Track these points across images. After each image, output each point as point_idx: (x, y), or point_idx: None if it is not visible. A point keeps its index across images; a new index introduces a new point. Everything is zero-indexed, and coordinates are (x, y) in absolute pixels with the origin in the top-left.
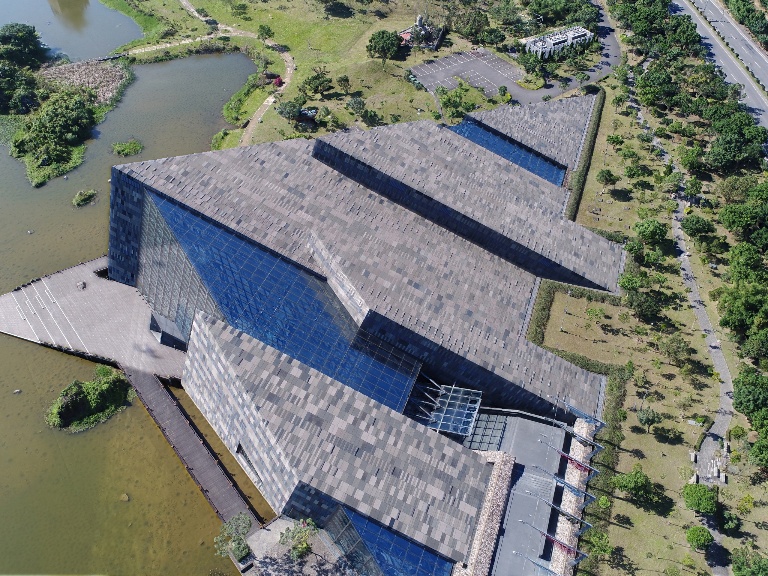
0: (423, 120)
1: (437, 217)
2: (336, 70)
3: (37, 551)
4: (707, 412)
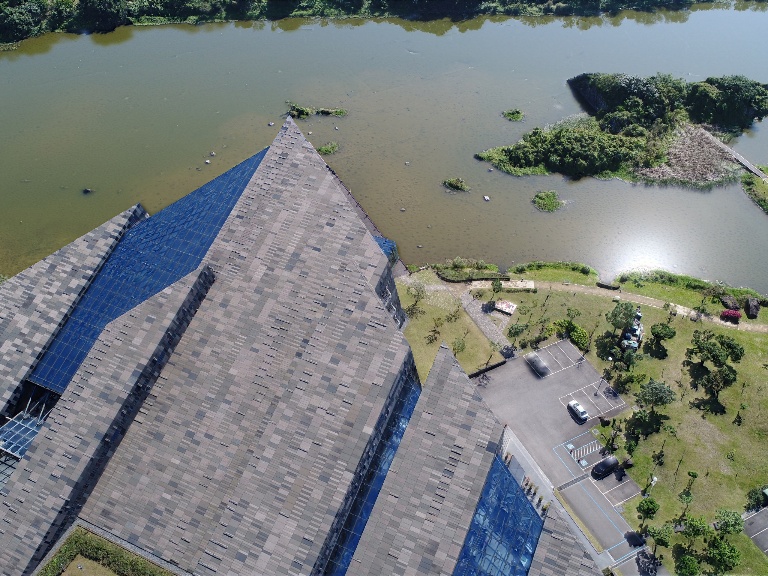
0: None
1: None
2: None
3: (80, 216)
4: None
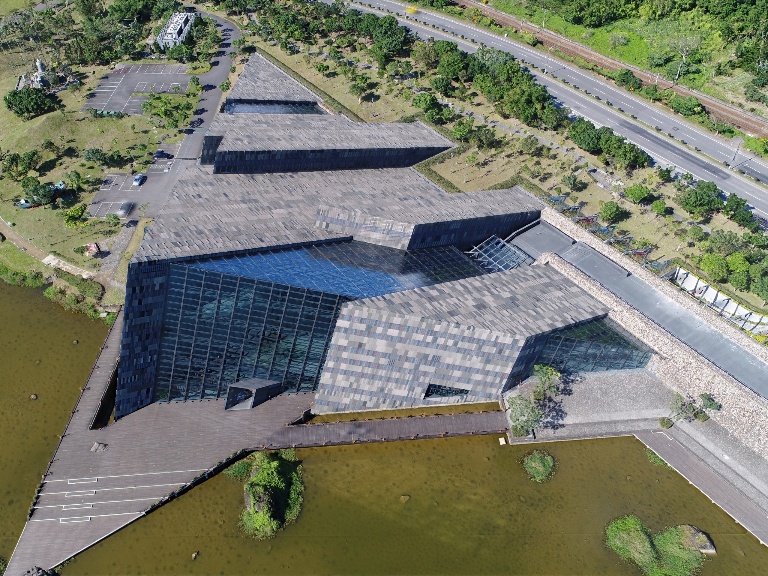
0: (217, 115)
1: (330, 165)
2: (15, 146)
3: None
4: (575, 164)
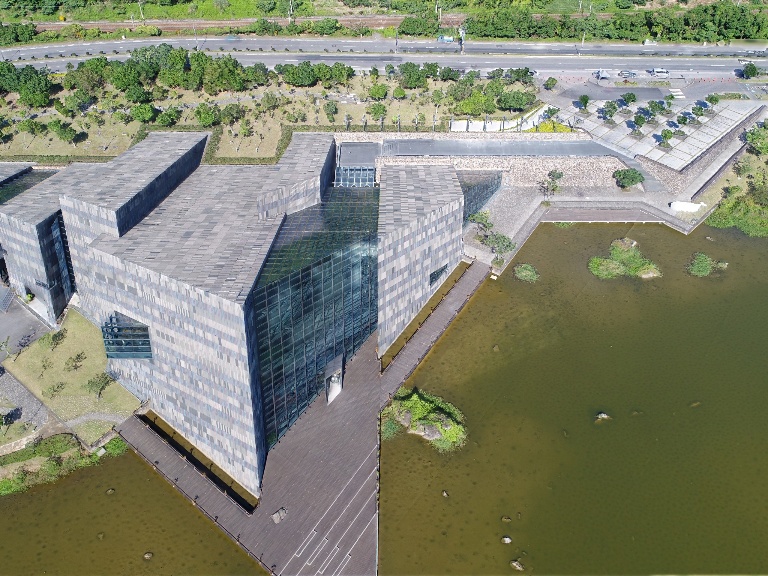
0: None
1: None
2: None
3: (566, 380)
4: None
